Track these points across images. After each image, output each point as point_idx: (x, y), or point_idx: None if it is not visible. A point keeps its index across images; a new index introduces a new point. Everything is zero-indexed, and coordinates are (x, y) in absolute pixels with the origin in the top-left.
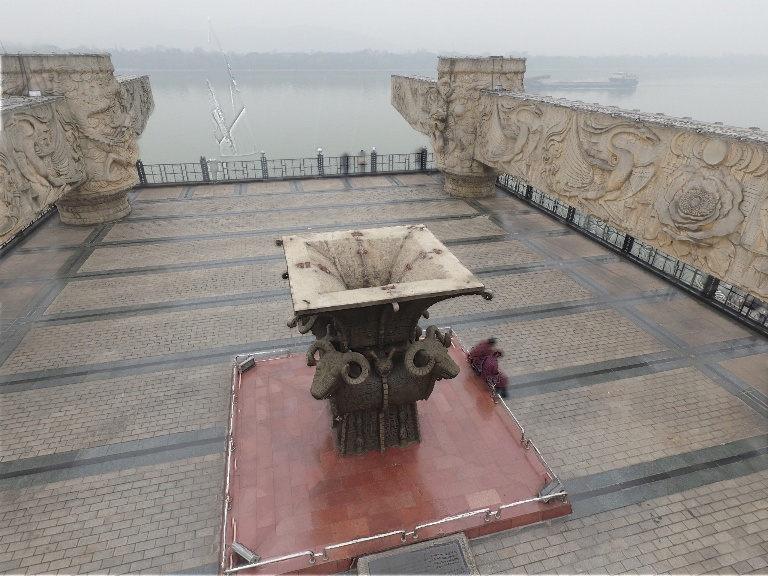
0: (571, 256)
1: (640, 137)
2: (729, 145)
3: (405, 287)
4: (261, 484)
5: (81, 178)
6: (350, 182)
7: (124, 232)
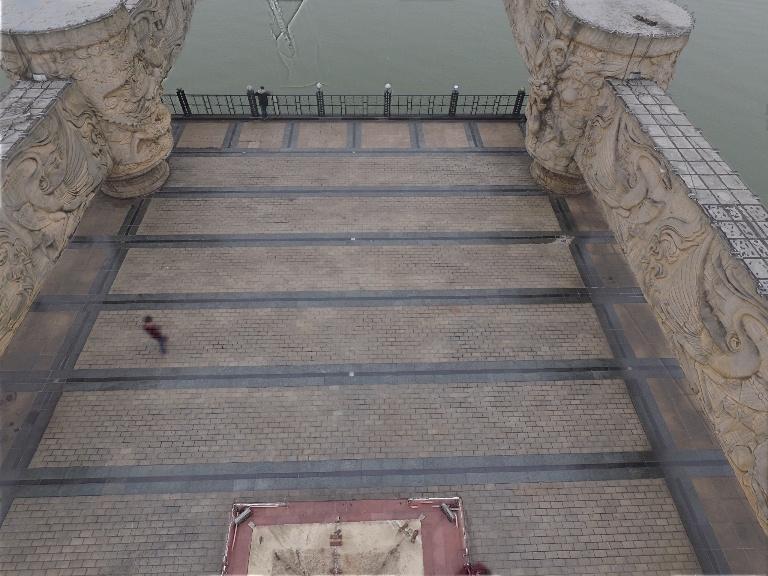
0: (648, 353)
1: None
2: None
3: None
4: None
5: (106, 170)
6: (419, 133)
7: (159, 217)
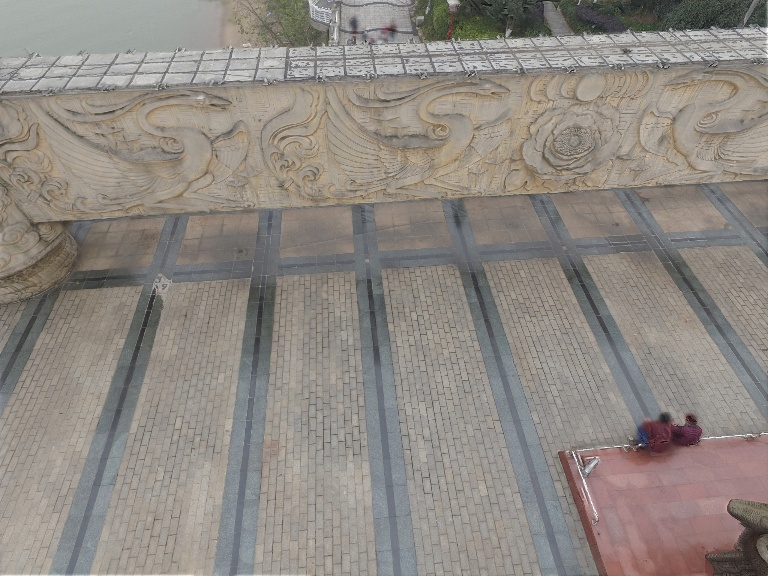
0: (347, 242)
1: (483, 95)
2: (605, 76)
3: None
4: None
5: None
6: None
7: None
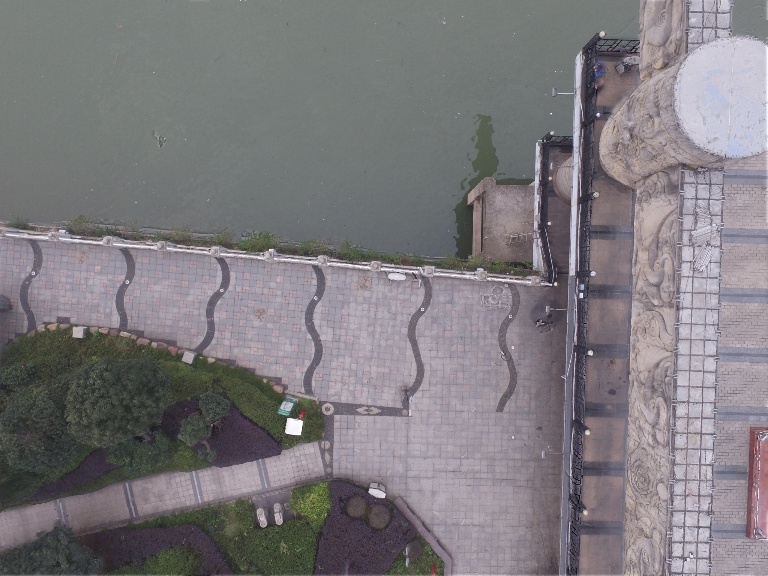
0: None
1: None
2: None
3: None
4: (764, 505)
5: None
6: None
7: None
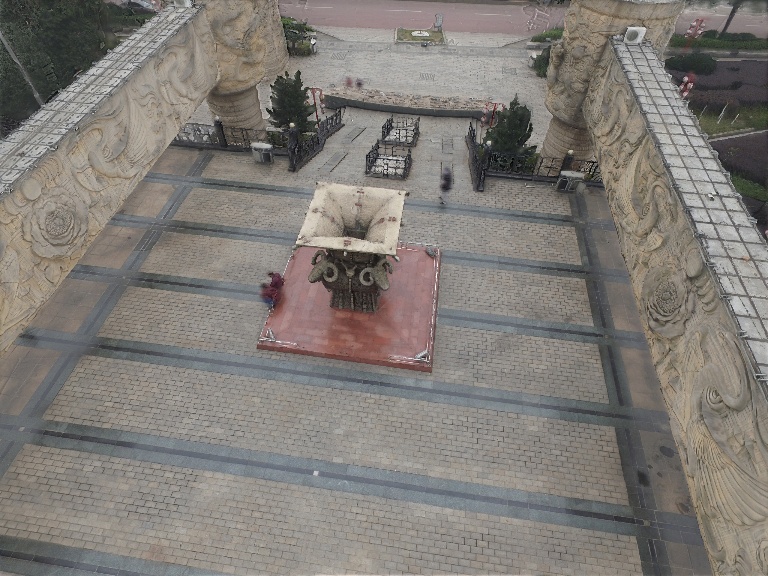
0: None
1: None
2: None
3: (353, 190)
4: (422, 278)
5: None
6: None
7: None
